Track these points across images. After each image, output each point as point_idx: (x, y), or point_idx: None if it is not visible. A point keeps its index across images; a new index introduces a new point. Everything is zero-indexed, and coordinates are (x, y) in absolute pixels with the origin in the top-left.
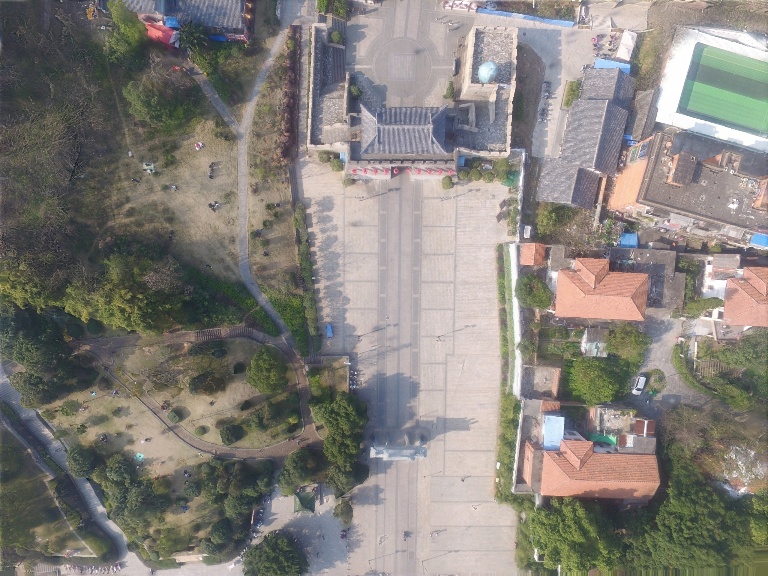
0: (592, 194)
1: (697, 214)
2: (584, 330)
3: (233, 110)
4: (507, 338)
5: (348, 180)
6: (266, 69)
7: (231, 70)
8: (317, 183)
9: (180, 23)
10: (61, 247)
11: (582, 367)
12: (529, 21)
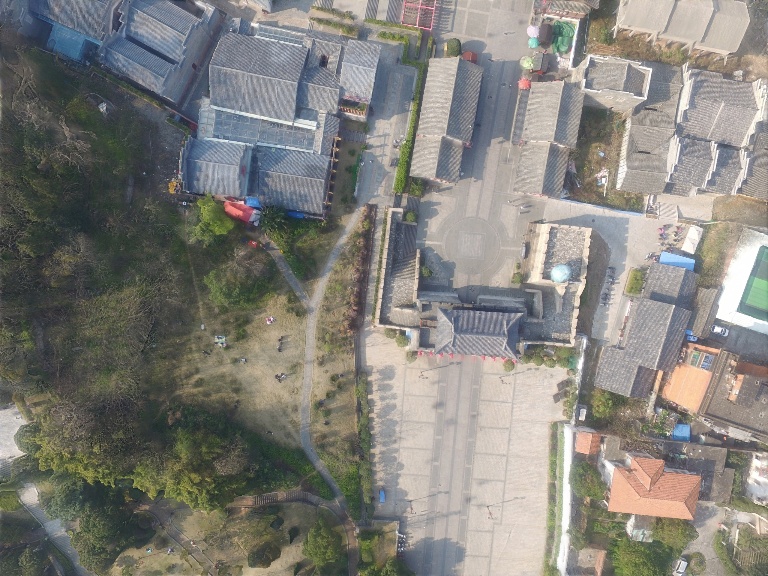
0: (649, 383)
1: (755, 430)
2: (631, 514)
3: (305, 285)
4: (555, 512)
5: (413, 358)
6: (340, 246)
7: (306, 247)
8: (380, 352)
9: (261, 204)
10: (136, 434)
11: (628, 552)
12: (599, 209)
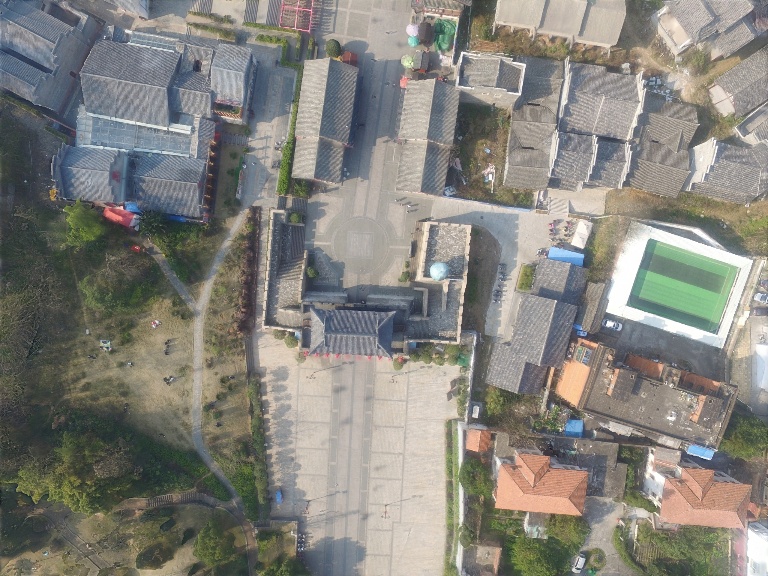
0: (540, 379)
1: (636, 424)
2: None
3: (191, 289)
4: (453, 510)
5: (301, 358)
6: (225, 248)
7: (190, 250)
8: (273, 353)
9: (140, 209)
10: (12, 439)
11: (522, 549)
12: (487, 205)
